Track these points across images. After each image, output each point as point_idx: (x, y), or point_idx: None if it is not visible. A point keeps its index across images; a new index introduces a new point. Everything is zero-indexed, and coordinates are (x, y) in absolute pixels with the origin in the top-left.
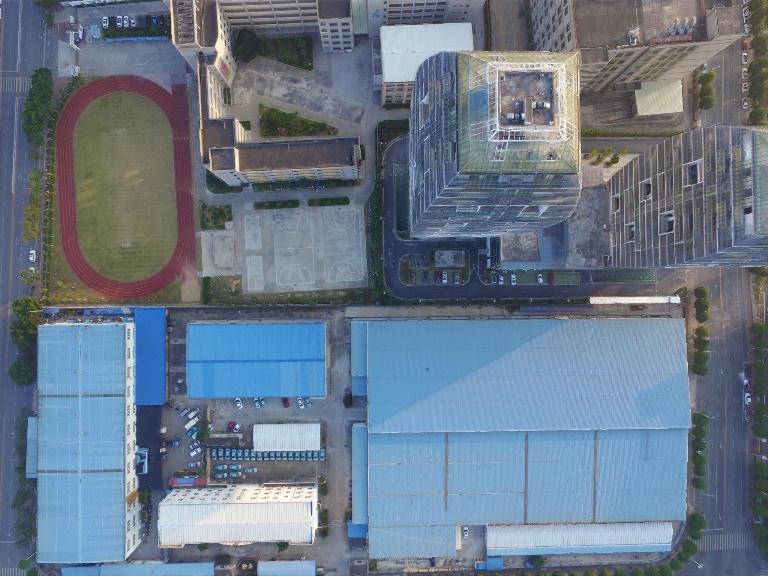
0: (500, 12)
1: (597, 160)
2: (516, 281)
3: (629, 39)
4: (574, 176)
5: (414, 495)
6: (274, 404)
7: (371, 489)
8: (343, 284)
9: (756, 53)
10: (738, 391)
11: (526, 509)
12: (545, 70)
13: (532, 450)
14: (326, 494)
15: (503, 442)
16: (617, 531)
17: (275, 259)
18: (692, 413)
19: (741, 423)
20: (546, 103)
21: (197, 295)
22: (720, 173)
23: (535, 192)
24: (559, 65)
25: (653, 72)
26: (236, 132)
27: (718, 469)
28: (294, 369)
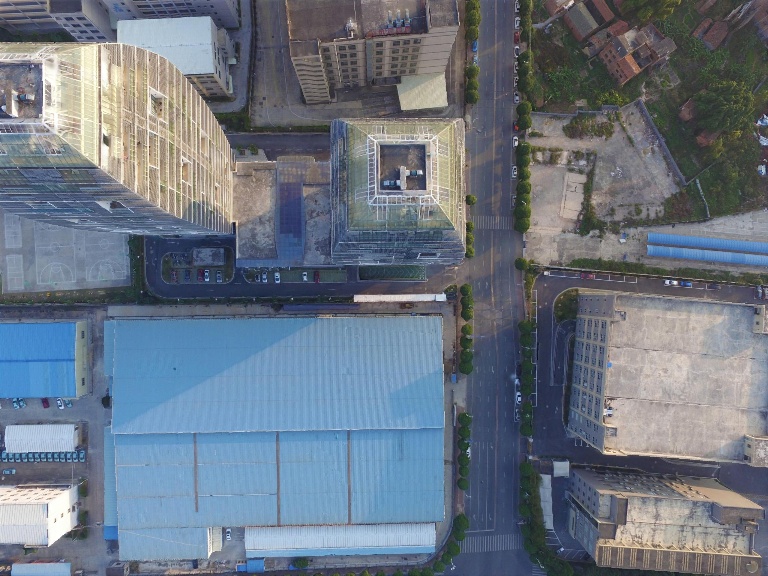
0: (267, 6)
1: None
2: (280, 279)
3: (347, 32)
4: (99, 170)
5: (163, 496)
6: (34, 405)
7: (119, 491)
8: (105, 283)
9: None
10: (510, 390)
11: (279, 510)
12: (33, 61)
13: (283, 451)
14: (86, 496)
15: (253, 443)
16: (378, 532)
17: (36, 258)
18: (459, 413)
19: (513, 422)
20: (28, 95)
21: None
22: (335, 167)
23: (81, 187)
24: (47, 55)
25: (403, 66)
26: None
27: (489, 469)
28: (43, 369)
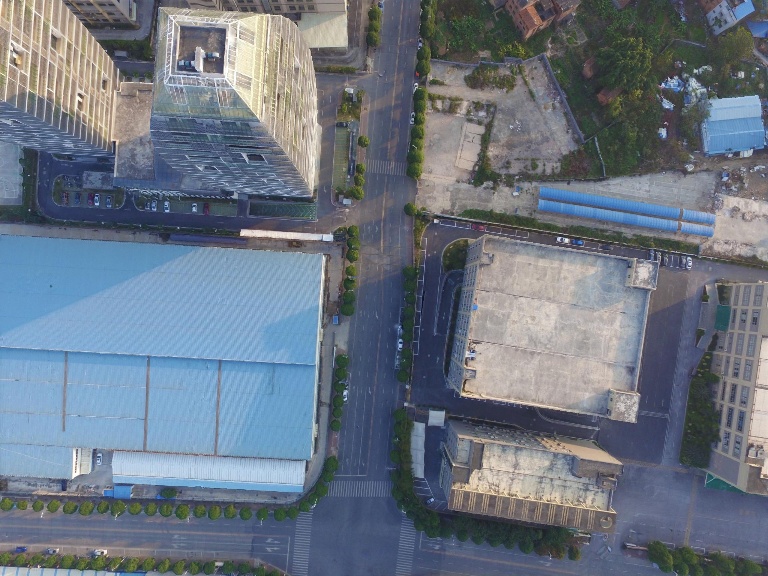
0: None
1: None
2: (170, 209)
3: None
4: None
5: (31, 413)
6: None
7: None
8: None
9: None
10: (392, 336)
11: (146, 436)
12: None
13: (154, 376)
14: None
15: (124, 366)
16: (246, 467)
17: None
18: (338, 354)
19: (393, 369)
20: None
21: None
22: None
23: None
24: None
25: (300, 0)
26: None
27: (365, 414)
28: None
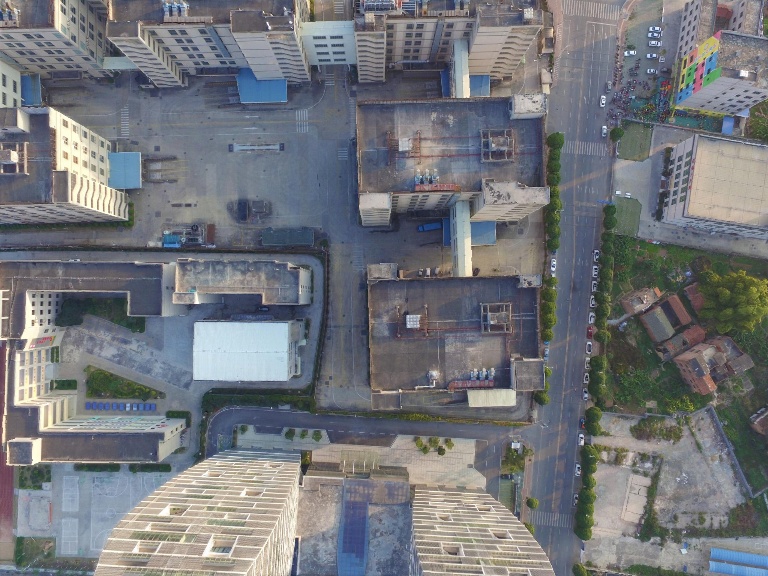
0: (340, 284)
1: (423, 450)
2: None
3: (429, 379)
4: None
5: None
6: None
7: None
8: None
9: (601, 343)
10: None
11: None
12: None
13: None
14: None
15: None
16: None
17: (91, 523)
18: None
19: None
20: None
21: (11, 553)
22: None
23: None
24: None
25: None
26: (40, 421)
27: None
28: None
